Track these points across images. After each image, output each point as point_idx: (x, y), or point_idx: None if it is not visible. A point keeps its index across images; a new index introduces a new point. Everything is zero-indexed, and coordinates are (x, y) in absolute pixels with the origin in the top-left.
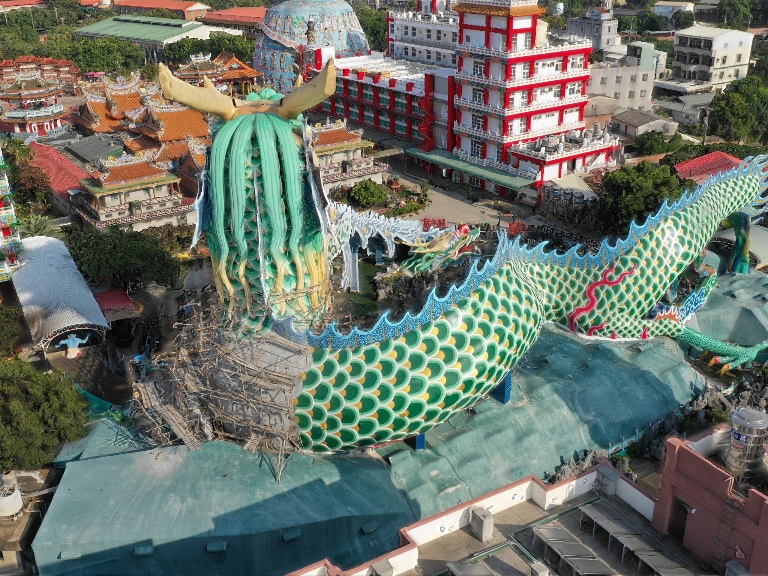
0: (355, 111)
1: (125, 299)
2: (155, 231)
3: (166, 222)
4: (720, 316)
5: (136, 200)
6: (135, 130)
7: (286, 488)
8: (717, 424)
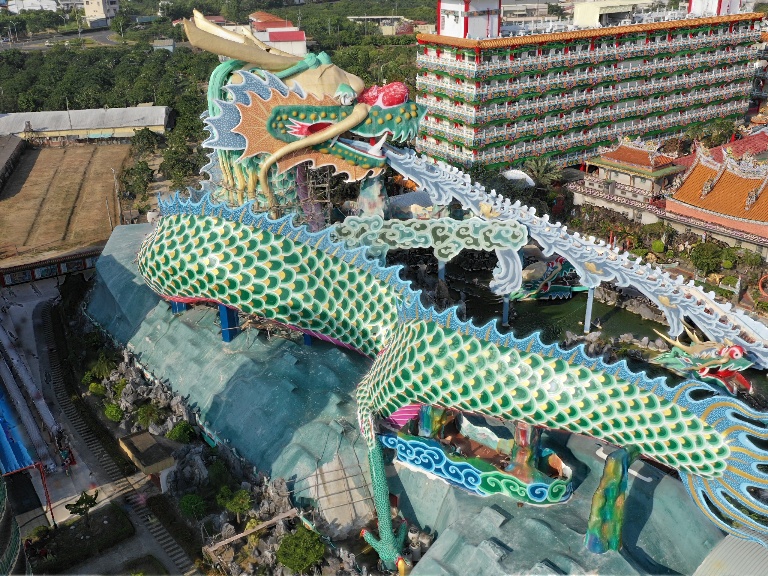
0: None
1: None
2: (603, 211)
3: (624, 210)
4: (451, 510)
5: (613, 180)
6: None
7: (129, 267)
8: (221, 490)
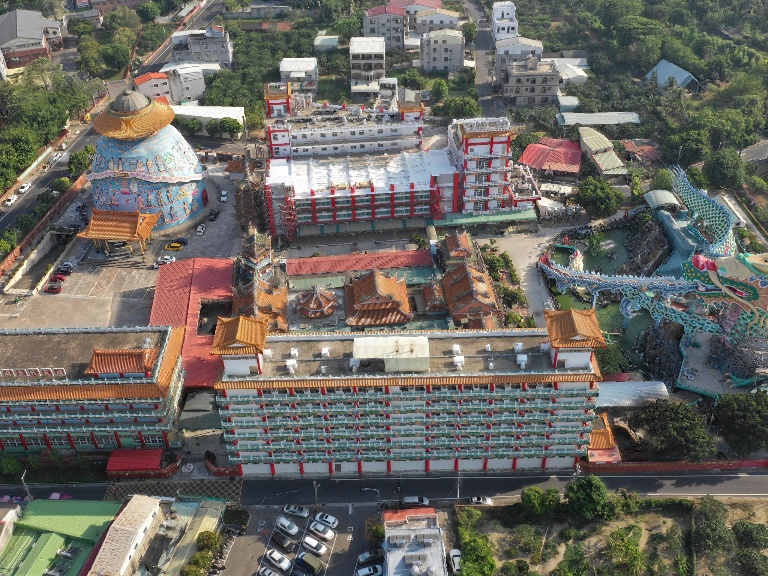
0: (344, 213)
1: (618, 374)
2: None
3: None
4: None
5: None
6: (328, 313)
7: None
8: None
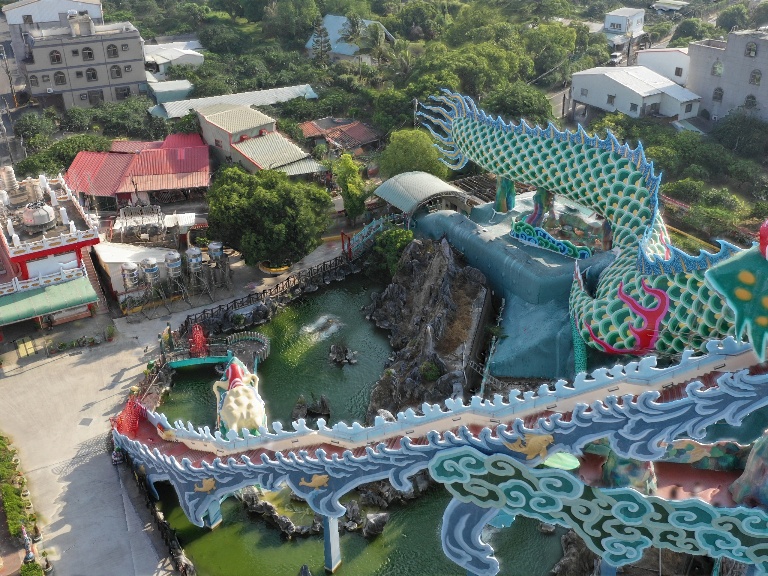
0: None
1: None
2: None
3: None
4: None
5: None
6: None
7: None
8: None
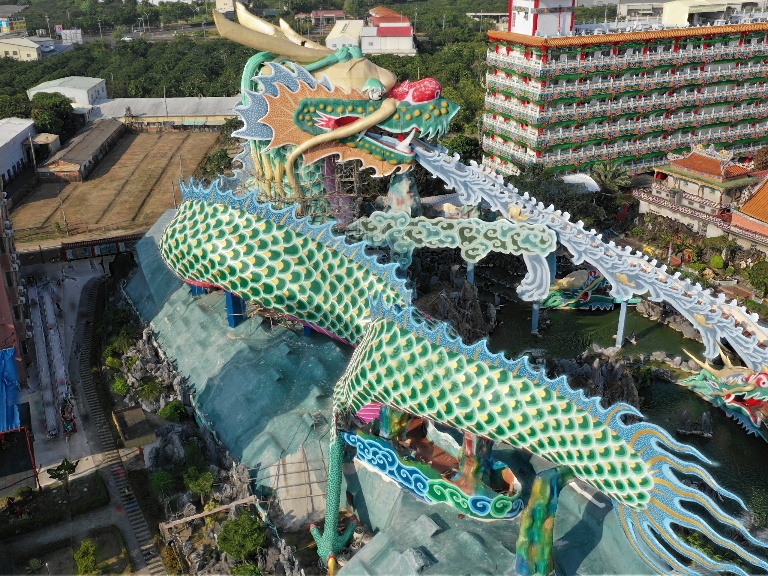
0: None
1: None
2: (667, 222)
3: (689, 222)
4: None
5: (681, 189)
6: None
7: None
8: None
